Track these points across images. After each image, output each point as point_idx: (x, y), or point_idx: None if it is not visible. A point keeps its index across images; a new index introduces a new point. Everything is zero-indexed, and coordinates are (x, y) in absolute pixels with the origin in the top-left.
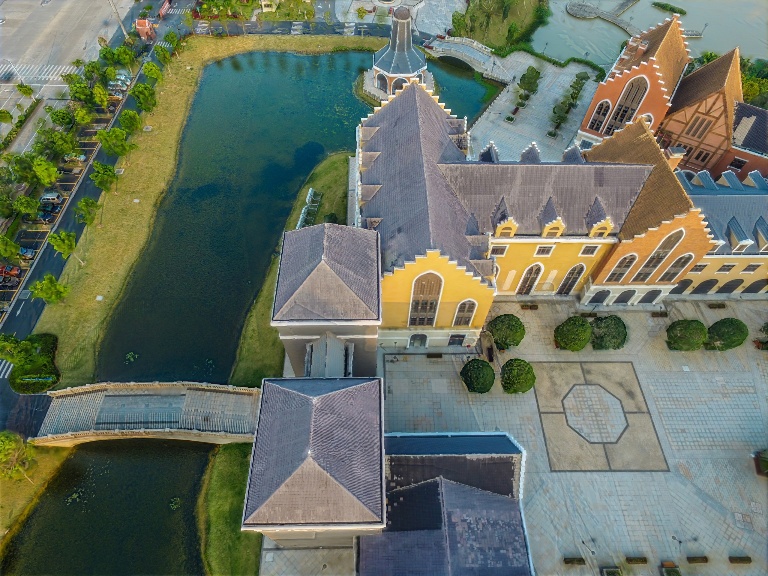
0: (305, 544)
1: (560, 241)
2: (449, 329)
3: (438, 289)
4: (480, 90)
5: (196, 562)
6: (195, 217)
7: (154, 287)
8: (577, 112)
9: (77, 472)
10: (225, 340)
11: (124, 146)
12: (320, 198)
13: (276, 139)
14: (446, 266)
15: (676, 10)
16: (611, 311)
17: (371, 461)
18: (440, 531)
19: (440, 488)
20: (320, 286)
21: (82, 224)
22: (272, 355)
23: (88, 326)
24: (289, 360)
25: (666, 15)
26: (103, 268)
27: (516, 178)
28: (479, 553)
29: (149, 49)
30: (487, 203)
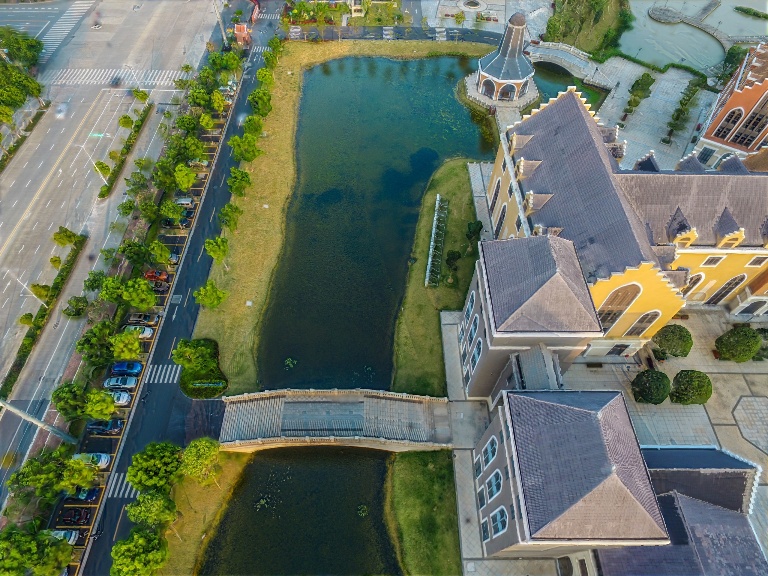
0: (512, 555)
1: (735, 252)
2: (619, 339)
3: (630, 300)
4: (582, 96)
5: (395, 570)
6: (324, 223)
7: (298, 293)
8: (686, 119)
9: (260, 478)
10: (379, 347)
11: (254, 152)
12: (447, 205)
13: (389, 145)
14: (652, 278)
15: (760, 15)
16: (763, 322)
17: (643, 476)
18: (688, 546)
19: (677, 502)
20: (550, 298)
21: (218, 229)
22: (432, 363)
23: (243, 331)
24: (450, 368)
25: (749, 20)
26: (247, 273)
27: (692, 188)
28: (729, 569)
29: (247, 54)
30: (662, 213)
